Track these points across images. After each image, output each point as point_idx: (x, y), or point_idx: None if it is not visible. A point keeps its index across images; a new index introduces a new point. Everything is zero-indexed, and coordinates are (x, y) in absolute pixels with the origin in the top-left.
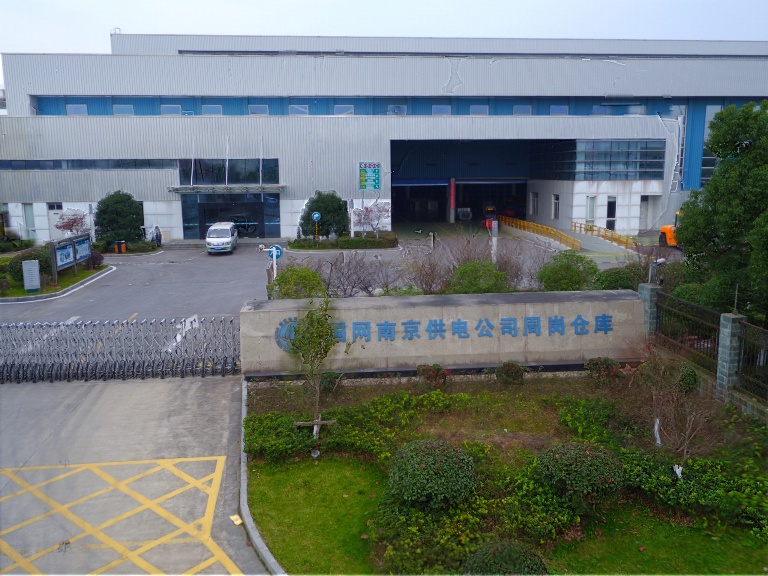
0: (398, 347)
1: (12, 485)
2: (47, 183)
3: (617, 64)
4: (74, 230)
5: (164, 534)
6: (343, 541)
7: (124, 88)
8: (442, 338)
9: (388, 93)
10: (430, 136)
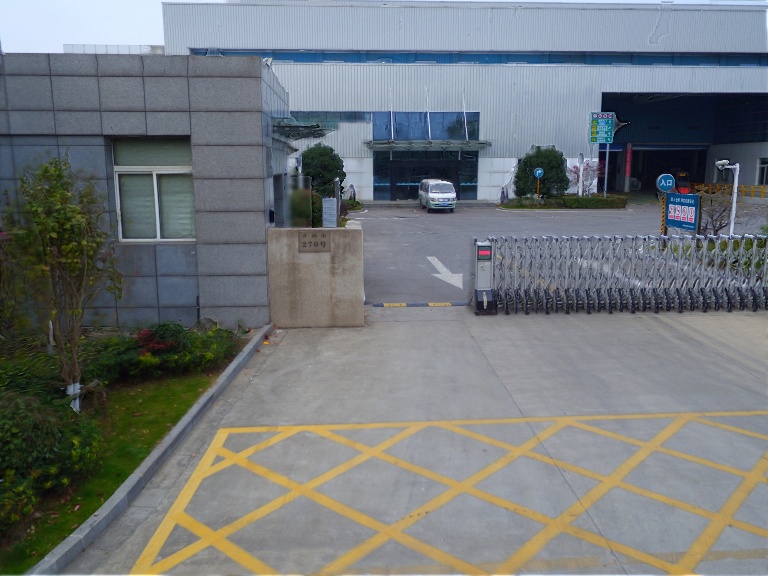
0: None
1: None
2: None
3: None
4: None
5: None
6: None
7: (289, 41)
8: None
9: (568, 48)
10: (645, 88)
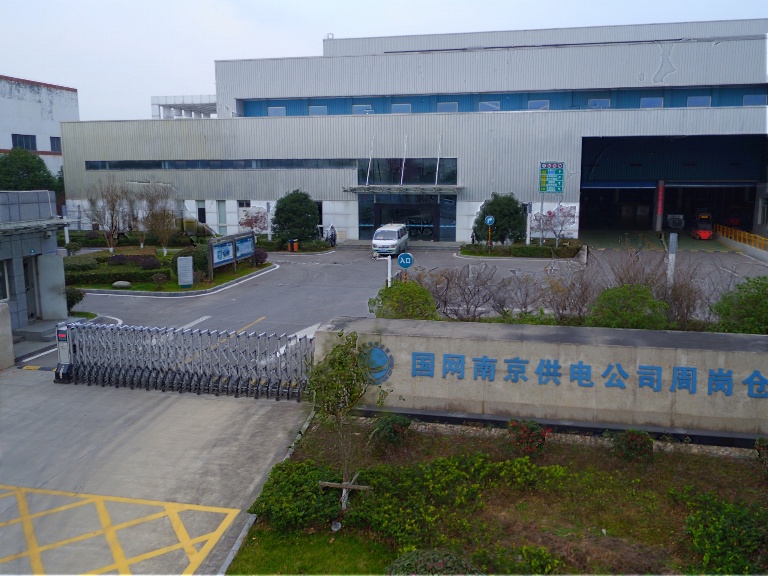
0: (498, 390)
1: (13, 510)
2: (238, 182)
3: None
4: (257, 227)
5: None
6: None
7: (319, 90)
8: (556, 384)
9: (589, 86)
10: (630, 132)
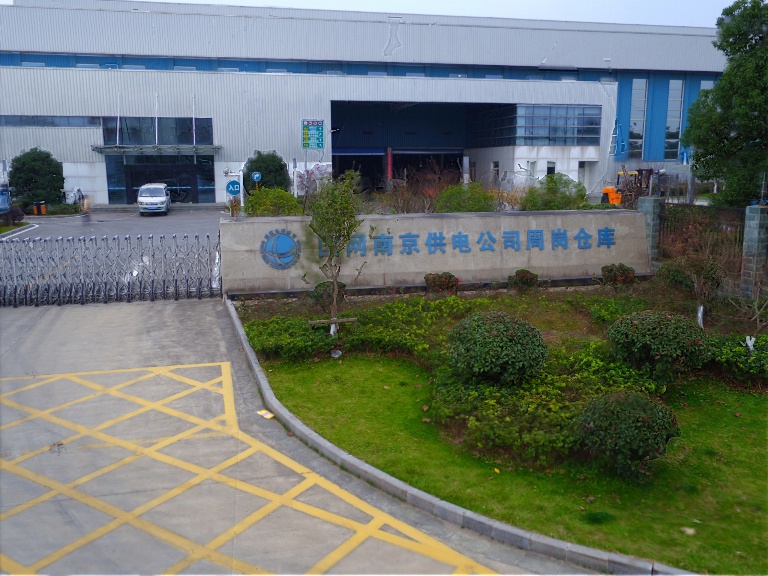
0: (396, 262)
1: None
2: None
3: (550, 35)
4: None
5: (181, 431)
6: (404, 424)
7: (35, 43)
8: (442, 252)
9: (323, 57)
10: (371, 97)
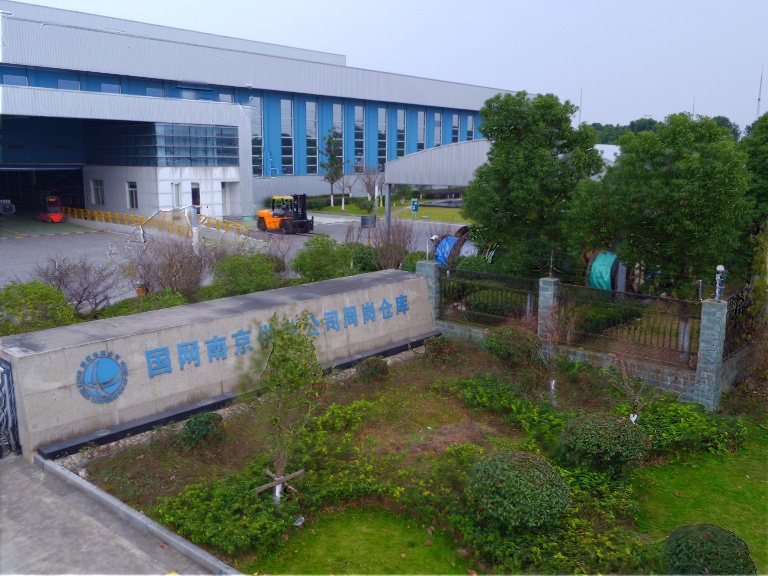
0: (231, 366)
1: None
2: None
3: (167, 47)
4: None
5: None
6: None
7: None
8: None
9: None
10: None
